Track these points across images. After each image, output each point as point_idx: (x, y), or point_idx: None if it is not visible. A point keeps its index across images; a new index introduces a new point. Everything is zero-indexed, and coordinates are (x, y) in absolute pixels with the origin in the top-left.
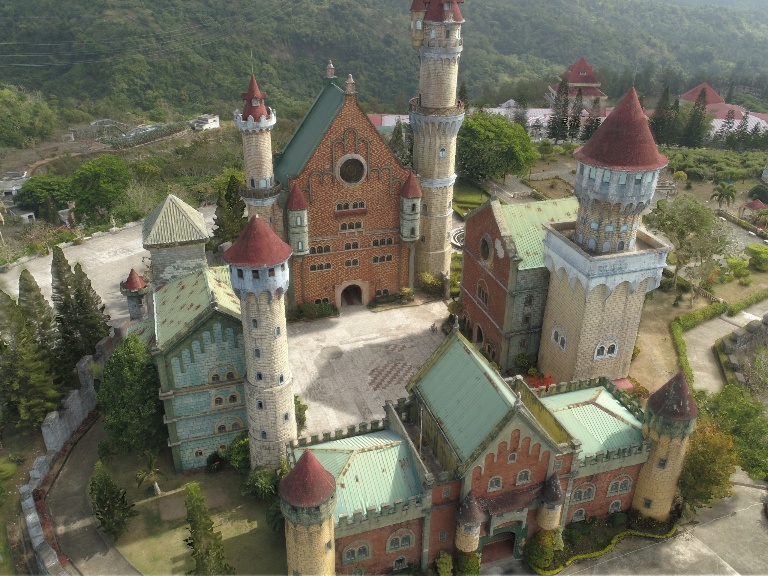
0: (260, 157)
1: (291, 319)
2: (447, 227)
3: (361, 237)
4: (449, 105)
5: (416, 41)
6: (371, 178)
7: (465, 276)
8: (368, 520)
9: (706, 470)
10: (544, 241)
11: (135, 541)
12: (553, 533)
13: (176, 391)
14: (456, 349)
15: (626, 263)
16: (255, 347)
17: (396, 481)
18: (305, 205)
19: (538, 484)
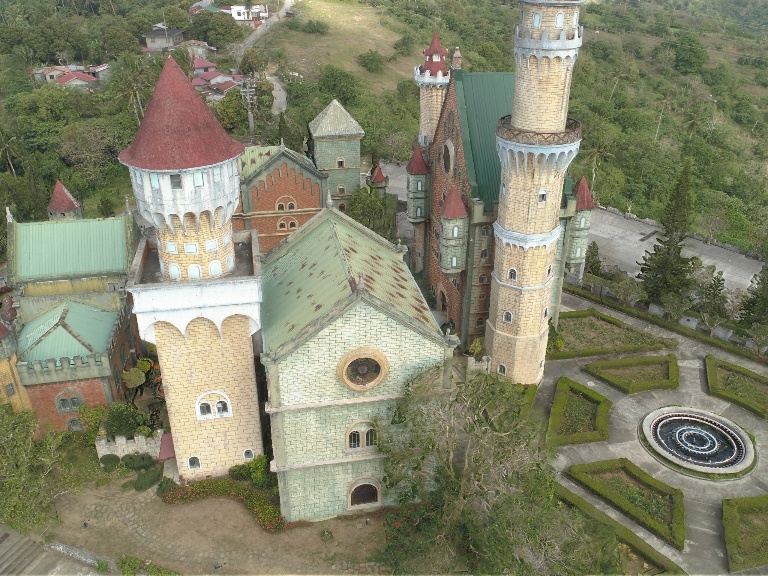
0: None
1: None
2: (505, 302)
3: None
4: (518, 125)
5: None
6: None
7: None
8: None
9: None
10: None
11: None
12: None
13: None
14: None
15: None
16: None
17: None
18: (411, 169)
19: None
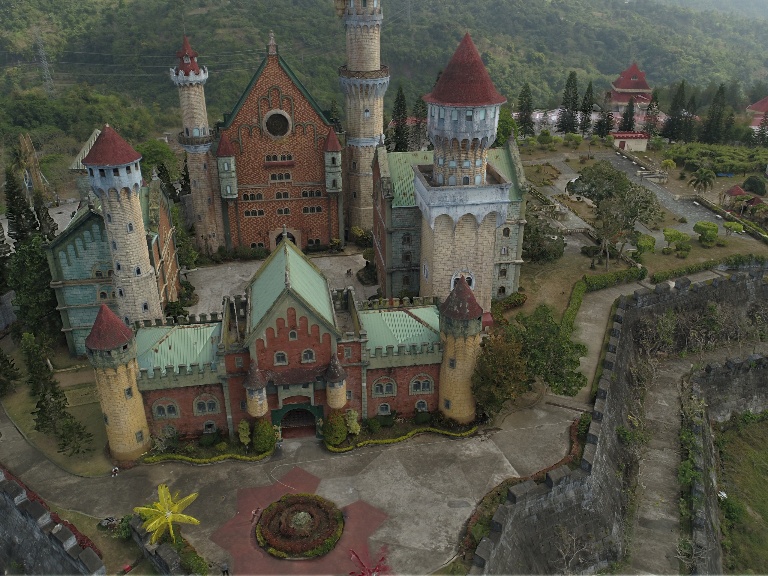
0: (192, 108)
1: (227, 259)
2: None
3: (291, 188)
4: (371, 69)
5: (338, 10)
6: (297, 133)
7: (374, 224)
8: (167, 377)
9: (489, 371)
10: (413, 181)
11: (17, 399)
12: (347, 416)
13: (65, 282)
14: (281, 252)
15: (467, 196)
16: (112, 240)
17: (203, 352)
18: (231, 152)
19: (325, 365)
